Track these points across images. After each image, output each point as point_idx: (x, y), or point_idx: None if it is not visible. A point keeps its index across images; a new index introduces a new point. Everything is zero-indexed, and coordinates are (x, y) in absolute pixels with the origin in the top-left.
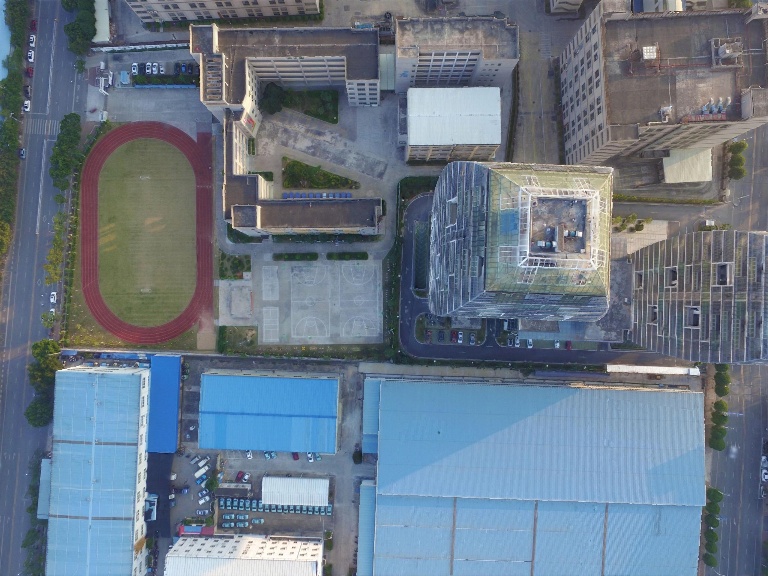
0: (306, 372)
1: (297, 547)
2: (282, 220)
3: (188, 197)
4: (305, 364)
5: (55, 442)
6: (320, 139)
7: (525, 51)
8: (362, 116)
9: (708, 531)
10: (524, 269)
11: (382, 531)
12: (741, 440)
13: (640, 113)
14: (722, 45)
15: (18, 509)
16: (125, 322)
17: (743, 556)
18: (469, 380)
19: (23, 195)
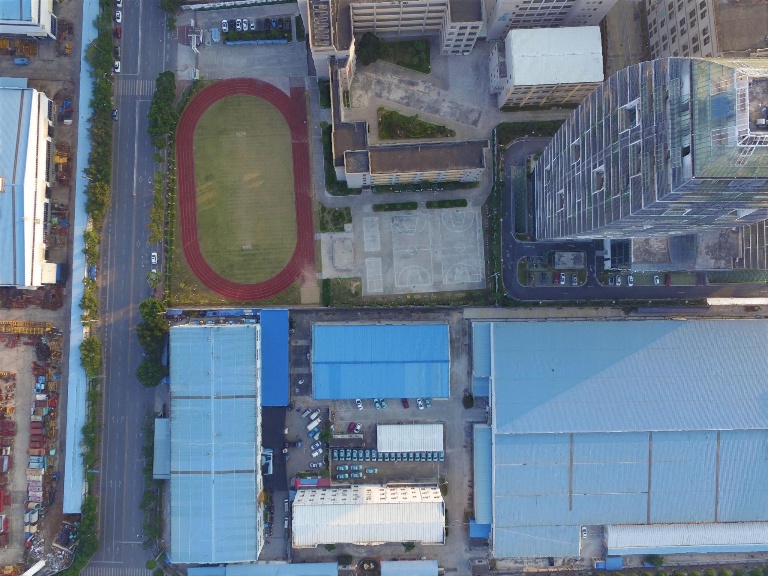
0: (411, 321)
1: (417, 492)
2: (391, 165)
3: (284, 152)
4: (410, 313)
5: (173, 398)
6: (414, 89)
7: None
8: (454, 65)
9: None
10: (742, 149)
11: (501, 470)
12: None
13: (748, 41)
14: None
15: (129, 472)
16: (227, 280)
17: None
18: (573, 320)
19: (117, 157)
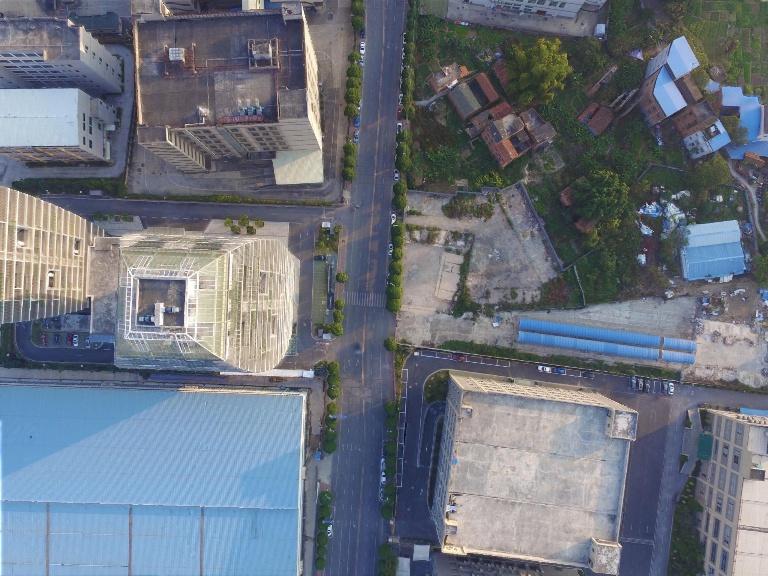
0: None
1: None
2: None
3: None
4: None
5: None
6: None
7: None
8: None
9: (319, 534)
10: None
11: None
12: (361, 442)
13: (178, 115)
14: None
15: None
16: None
17: (363, 558)
18: (85, 383)
19: None
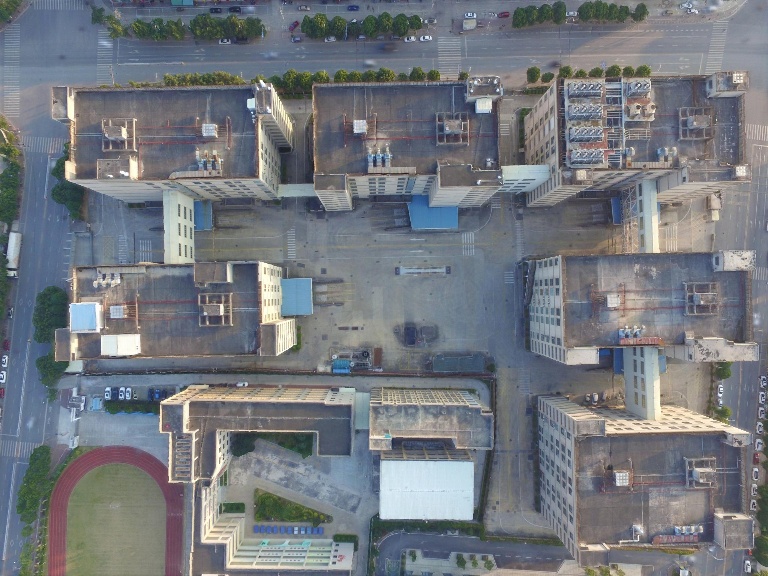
0: None
1: None
2: None
3: (158, 524)
4: None
5: None
6: (293, 471)
7: (504, 387)
8: None
9: None
10: None
11: None
12: None
13: (612, 529)
14: (696, 469)
15: None
16: None
17: None
18: None
19: None
